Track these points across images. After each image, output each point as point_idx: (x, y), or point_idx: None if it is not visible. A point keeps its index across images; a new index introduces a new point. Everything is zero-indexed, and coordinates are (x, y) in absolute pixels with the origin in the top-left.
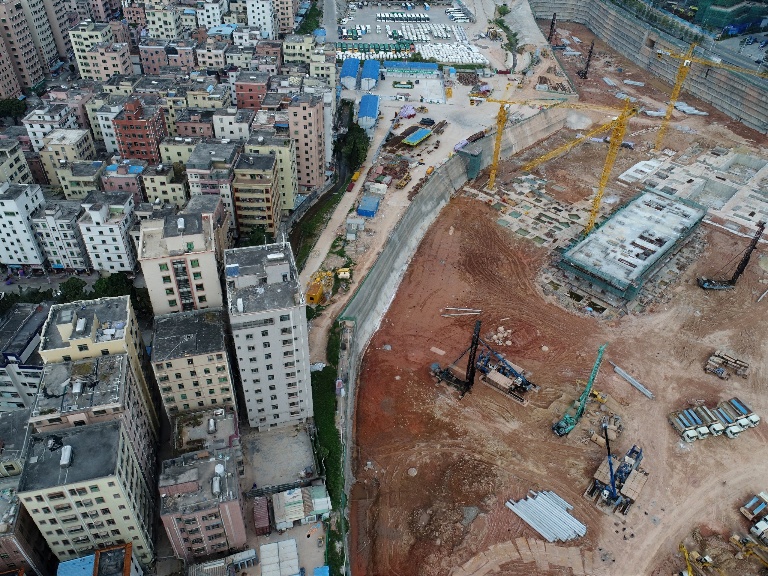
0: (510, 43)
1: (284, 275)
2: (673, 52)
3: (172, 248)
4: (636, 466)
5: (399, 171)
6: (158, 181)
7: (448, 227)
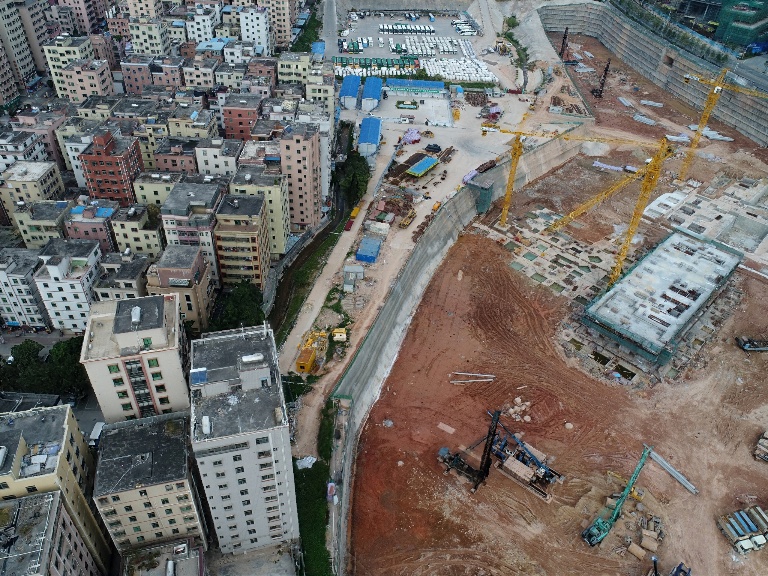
0: (520, 59)
1: (263, 380)
2: (702, 77)
3: (124, 345)
4: None
5: (403, 207)
6: (129, 227)
7: (456, 271)
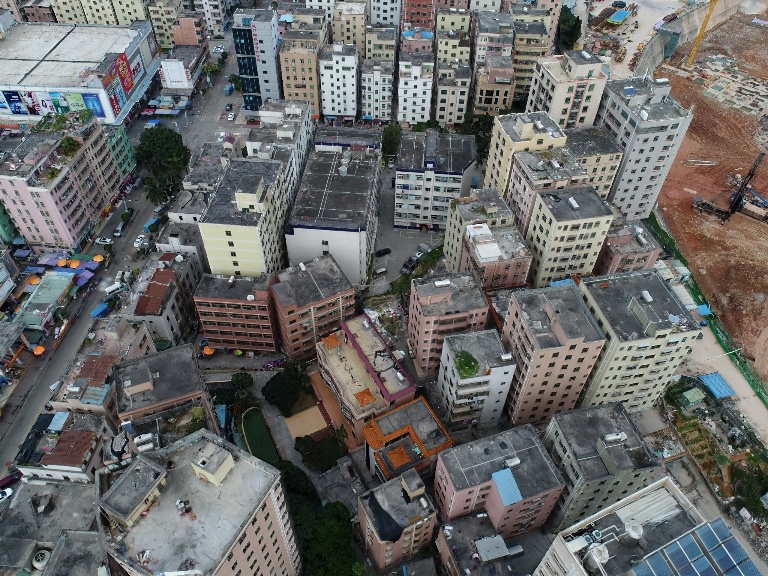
0: None
1: (663, 97)
2: None
3: (578, 75)
4: None
5: (612, 47)
6: (451, 44)
7: None
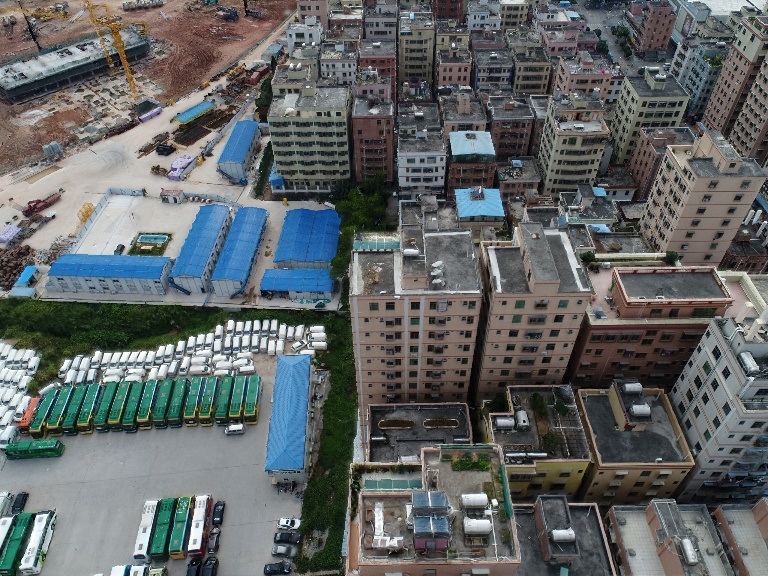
0: None
1: None
2: None
3: None
4: None
5: None
6: None
7: None
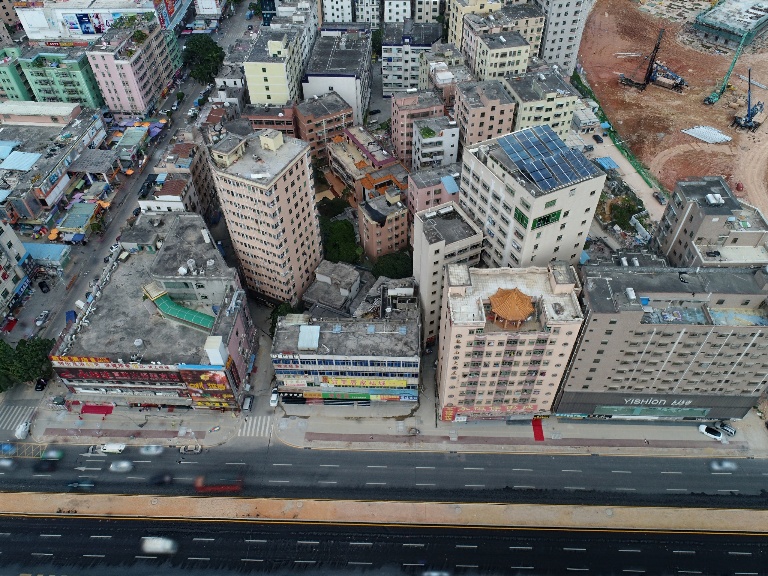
0: None
1: None
2: None
3: None
4: (760, 112)
5: None
6: None
7: (603, 13)
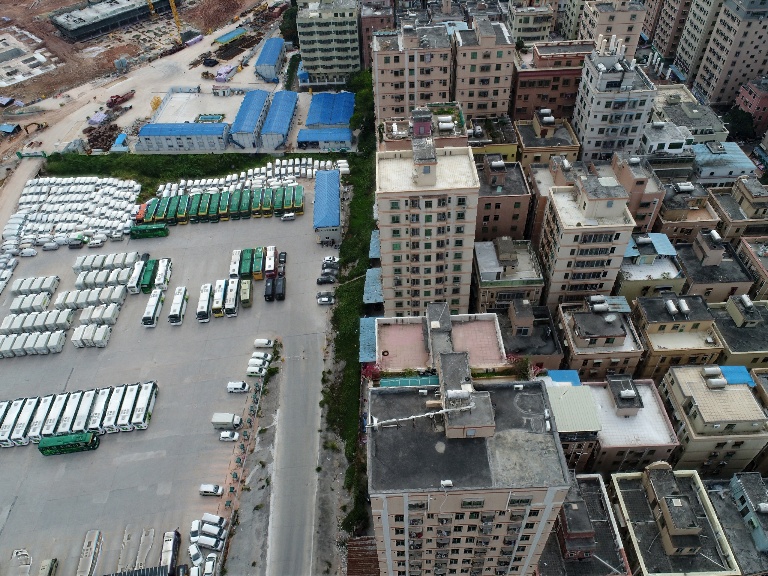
0: None
1: None
2: None
3: None
4: None
5: None
6: None
7: None
